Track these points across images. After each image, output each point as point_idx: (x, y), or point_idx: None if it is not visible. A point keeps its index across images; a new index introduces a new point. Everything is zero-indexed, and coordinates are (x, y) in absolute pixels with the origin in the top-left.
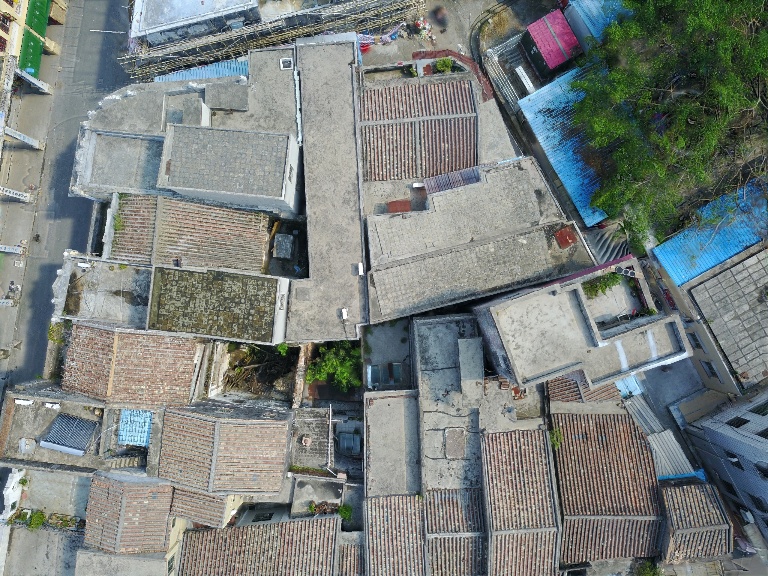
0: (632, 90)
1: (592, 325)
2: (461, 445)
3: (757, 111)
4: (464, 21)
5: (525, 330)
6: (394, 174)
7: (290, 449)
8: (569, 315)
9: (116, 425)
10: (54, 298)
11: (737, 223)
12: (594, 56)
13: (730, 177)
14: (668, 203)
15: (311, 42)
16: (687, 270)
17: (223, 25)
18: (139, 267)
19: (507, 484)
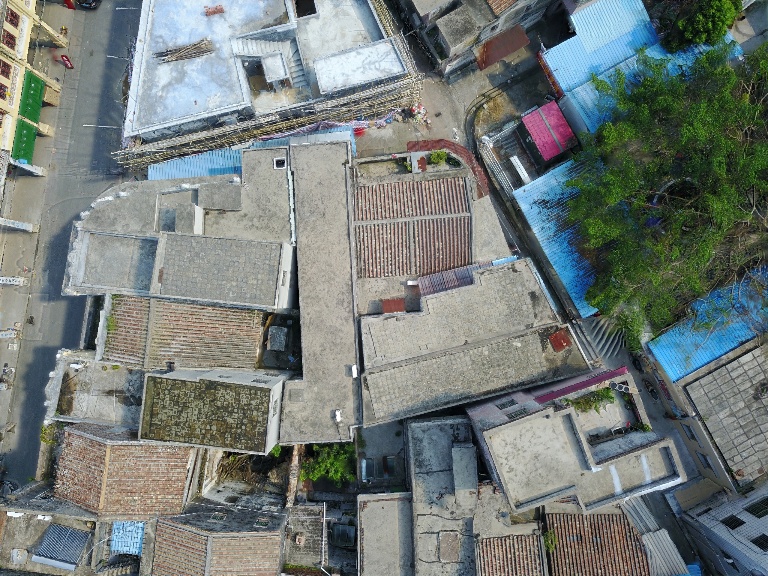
0: (627, 193)
1: (585, 450)
2: (455, 549)
3: (752, 220)
4: (459, 105)
5: (518, 453)
6: (388, 271)
7: (284, 550)
8: (562, 438)
9: (108, 537)
10: (47, 400)
11: (732, 317)
12: (589, 153)
13: (725, 280)
14: (663, 307)
15: (305, 141)
16: (682, 365)
17: (217, 120)
18: (132, 367)
19: None
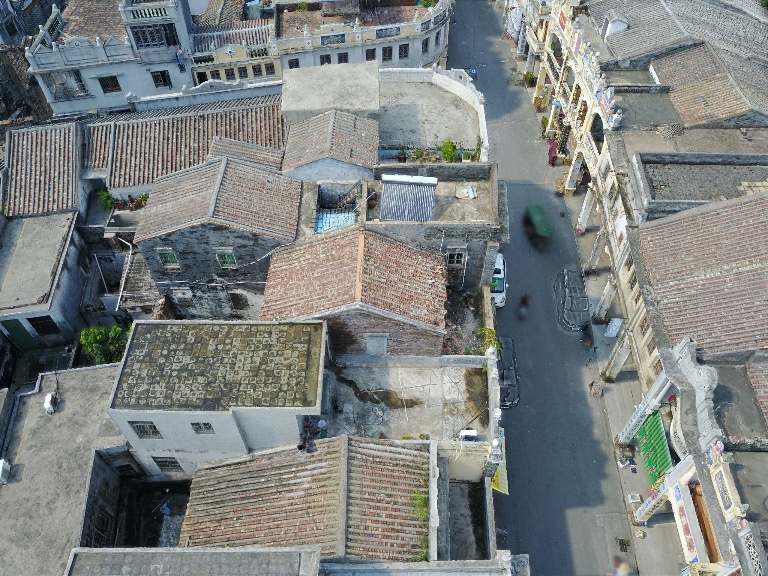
0: None
1: None
2: None
3: None
4: None
5: None
6: None
7: None
8: None
9: None
10: None
11: None
12: None
13: None
14: None
15: None
16: None
17: None
18: None
19: None
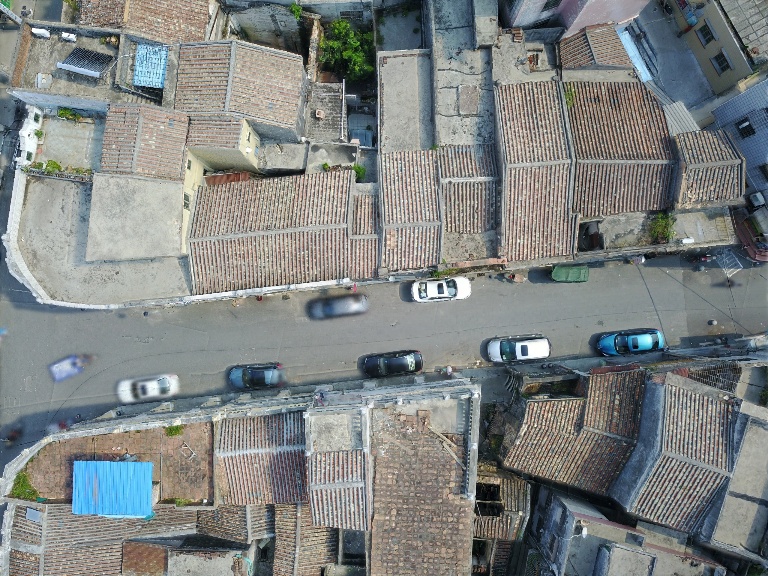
0: None
1: None
2: (474, 101)
3: None
4: None
5: None
6: None
7: None
8: None
9: None
10: None
11: None
12: None
13: None
14: None
15: None
16: None
17: None
18: None
19: (521, 126)
